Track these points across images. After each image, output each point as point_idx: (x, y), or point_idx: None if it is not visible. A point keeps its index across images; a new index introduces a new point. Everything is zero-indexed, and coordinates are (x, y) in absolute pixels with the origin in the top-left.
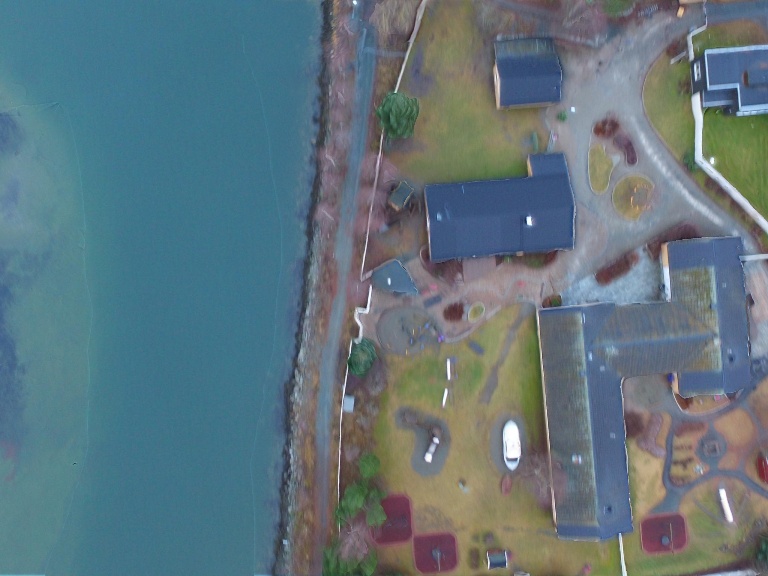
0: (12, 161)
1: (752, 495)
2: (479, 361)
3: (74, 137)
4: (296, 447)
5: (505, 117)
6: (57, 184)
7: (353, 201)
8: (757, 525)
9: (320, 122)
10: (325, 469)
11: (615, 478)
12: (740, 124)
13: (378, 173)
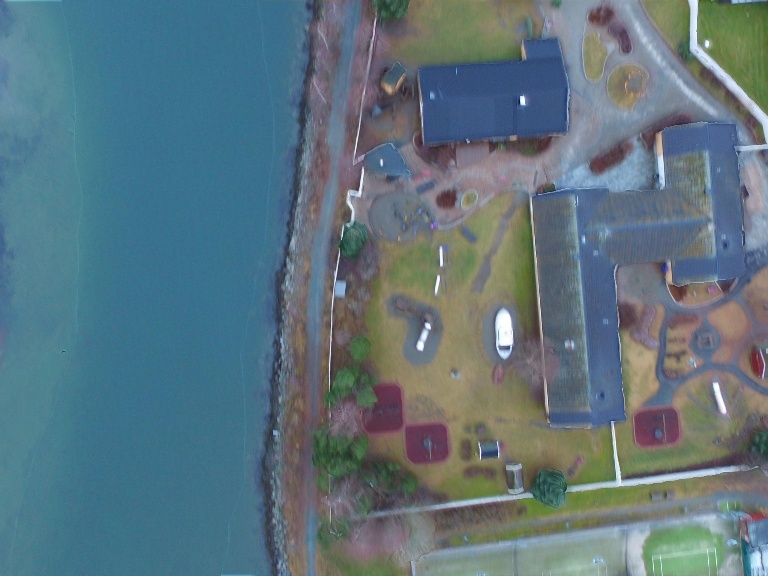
0: (2, 43)
1: (746, 390)
2: (472, 249)
3: (65, 20)
4: (287, 336)
5: (499, 3)
6: (48, 67)
7: (346, 86)
8: (751, 420)
9: (313, 9)
10: (316, 357)
11: (608, 365)
12: (735, 13)
13: (371, 57)
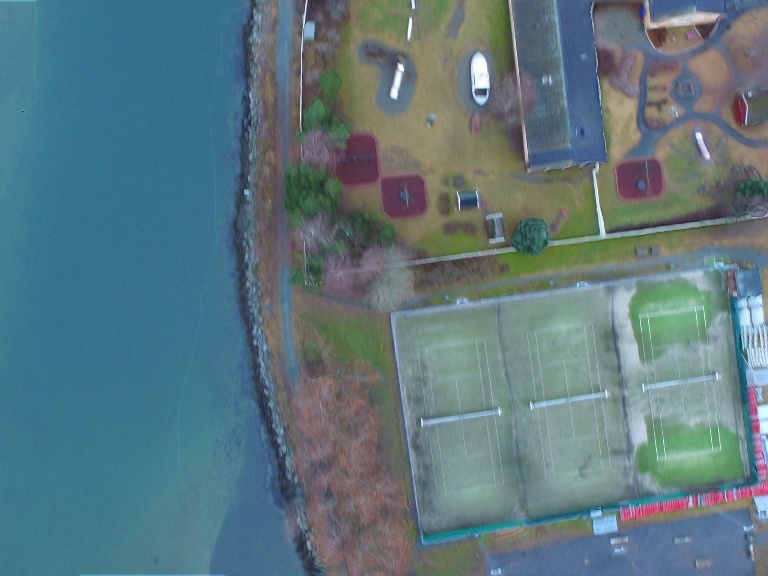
0: None
1: (729, 141)
2: None
3: None
4: (256, 89)
5: None
6: None
7: None
8: (735, 171)
9: None
10: (286, 108)
11: (587, 103)
12: None
13: None
